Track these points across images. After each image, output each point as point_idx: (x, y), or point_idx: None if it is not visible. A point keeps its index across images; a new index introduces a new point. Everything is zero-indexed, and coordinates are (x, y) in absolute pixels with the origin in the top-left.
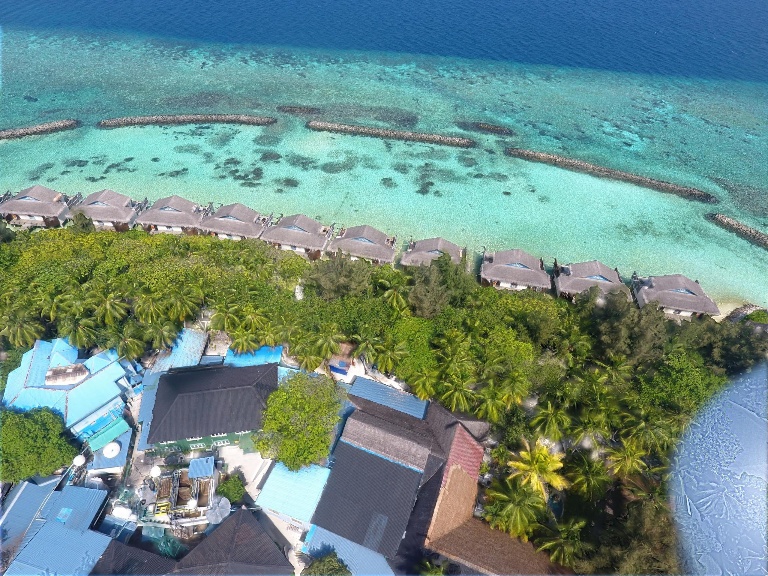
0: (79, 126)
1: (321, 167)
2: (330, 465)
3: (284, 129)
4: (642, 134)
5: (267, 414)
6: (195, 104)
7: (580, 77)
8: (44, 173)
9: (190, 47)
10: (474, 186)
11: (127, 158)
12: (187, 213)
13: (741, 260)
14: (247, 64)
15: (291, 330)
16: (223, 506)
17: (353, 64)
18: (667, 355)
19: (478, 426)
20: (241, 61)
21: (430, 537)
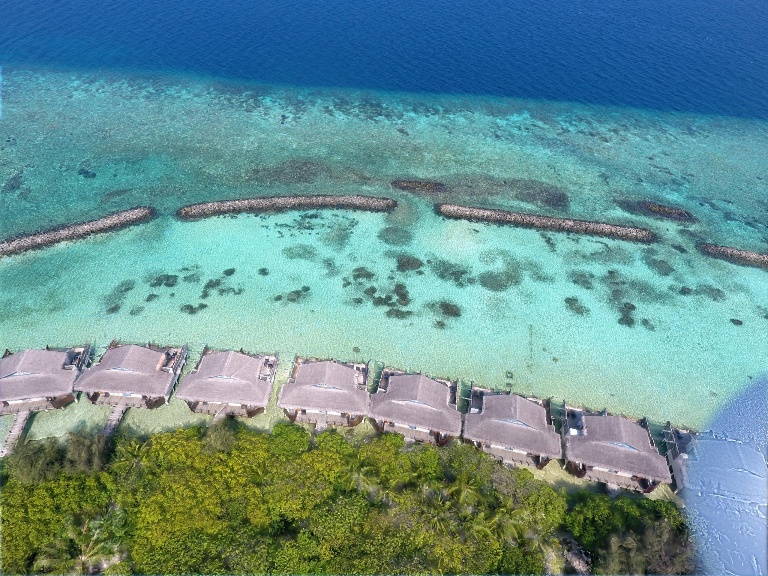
0: (155, 217)
1: (479, 280)
2: None
3: (411, 217)
4: None
5: None
6: (290, 179)
7: (727, 129)
8: (124, 299)
9: (260, 93)
10: (688, 310)
11: (227, 270)
12: (350, 392)
13: None
14: (334, 117)
15: None
16: None
17: (457, 115)
18: None
19: None
20: (325, 112)
21: None
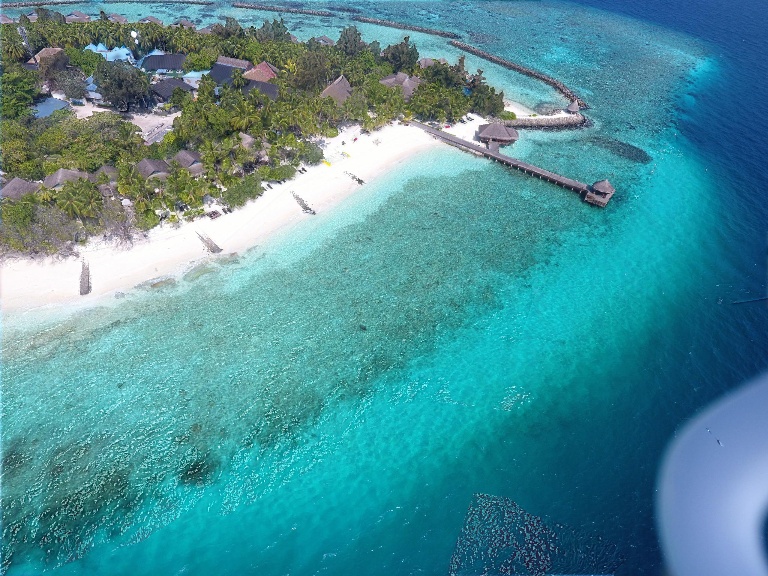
0: (91, 2)
1: None
2: (211, 69)
3: (218, 6)
4: (442, 15)
5: None
6: None
7: None
8: None
9: None
10: (323, 29)
11: (122, 14)
12: None
13: (452, 55)
14: None
15: None
16: None
17: None
18: None
19: (276, 69)
20: None
21: (242, 76)
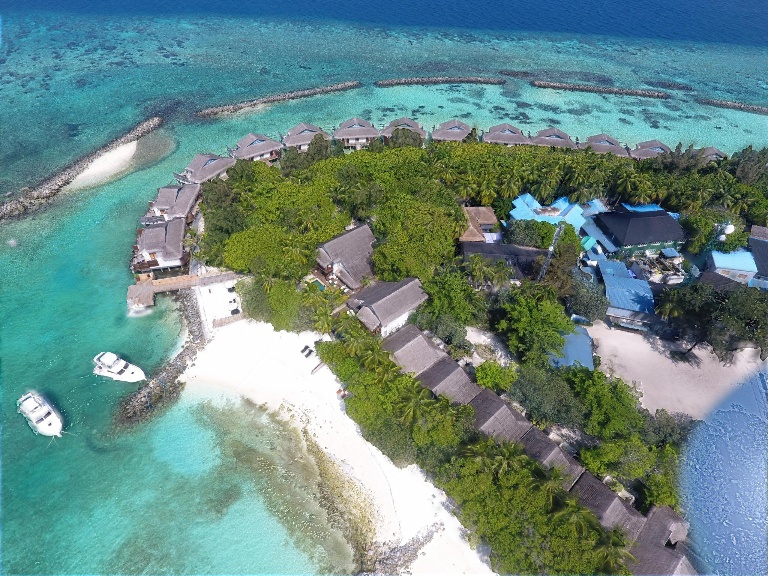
0: (362, 85)
1: (567, 112)
2: (750, 249)
3: (517, 87)
4: None
5: (698, 225)
6: (433, 70)
7: (717, 49)
8: (371, 116)
9: (386, 29)
10: (690, 123)
11: (420, 106)
12: (520, 134)
13: None
14: (444, 41)
15: (672, 189)
16: (694, 270)
17: (527, 41)
18: None
19: None
20: (437, 39)
21: None
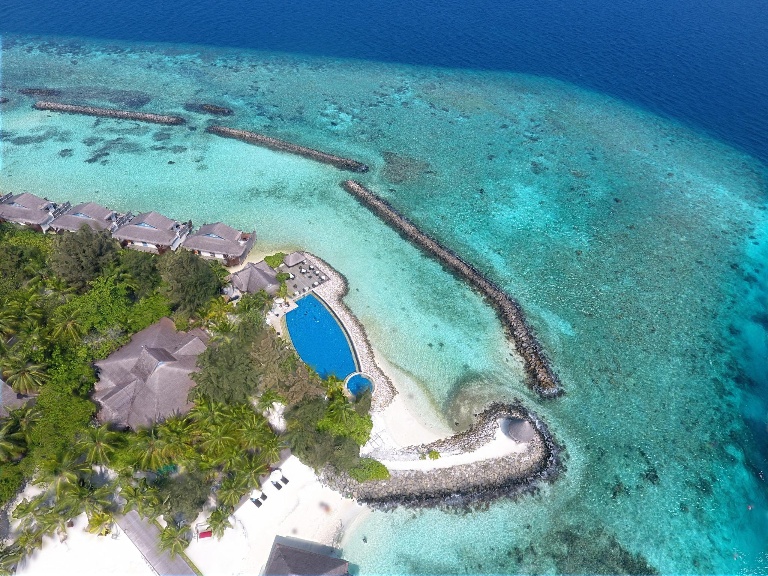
0: None
1: (12, 140)
2: None
3: (8, 108)
4: (357, 115)
5: None
6: None
7: (350, 67)
8: None
9: None
10: (146, 157)
11: None
12: None
13: (336, 217)
14: (28, 52)
15: None
16: None
17: (136, 54)
18: (98, 277)
19: None
20: (25, 50)
21: None
